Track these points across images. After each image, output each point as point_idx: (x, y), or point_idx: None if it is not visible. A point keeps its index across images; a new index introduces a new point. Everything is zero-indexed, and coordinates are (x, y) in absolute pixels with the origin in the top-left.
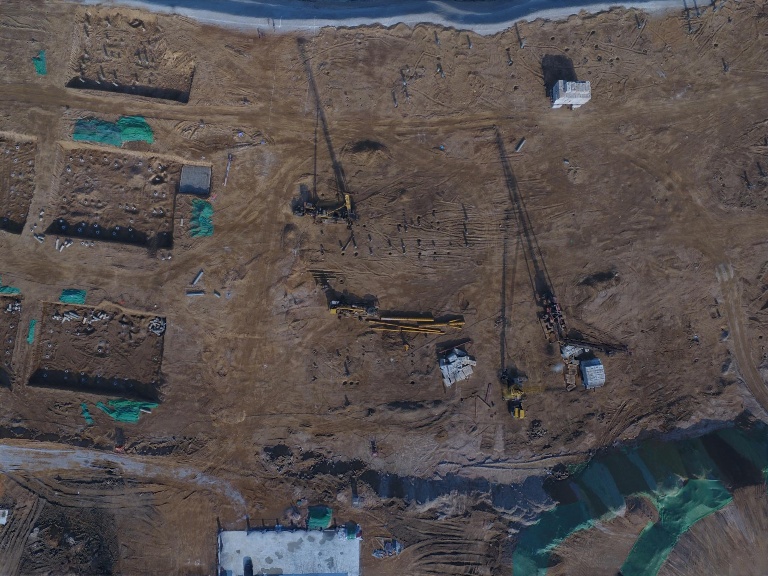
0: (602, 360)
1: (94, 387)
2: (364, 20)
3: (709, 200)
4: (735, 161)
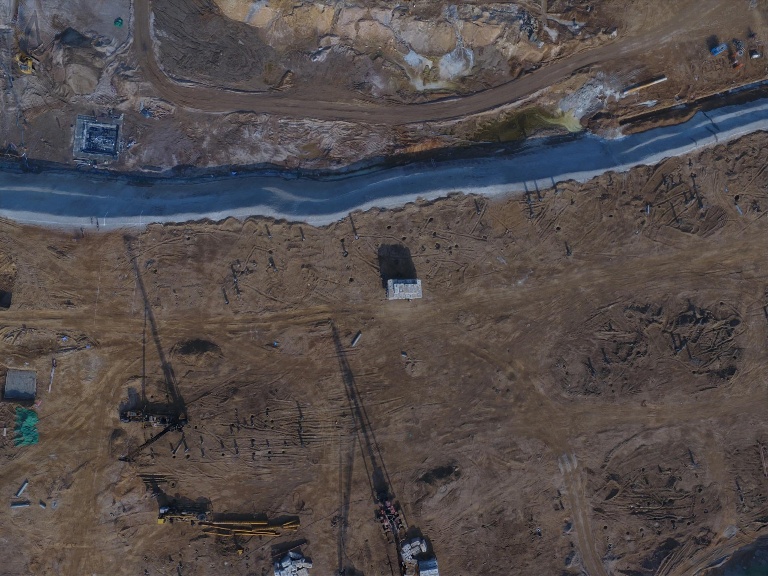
0: (442, 557)
1: None
2: (192, 216)
3: (552, 388)
4: (579, 348)
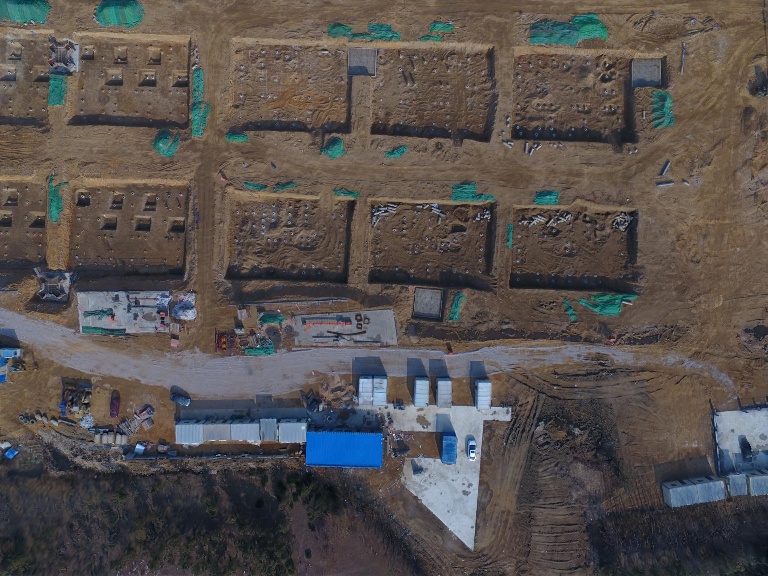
0: None
1: (566, 286)
2: None
3: None
4: None
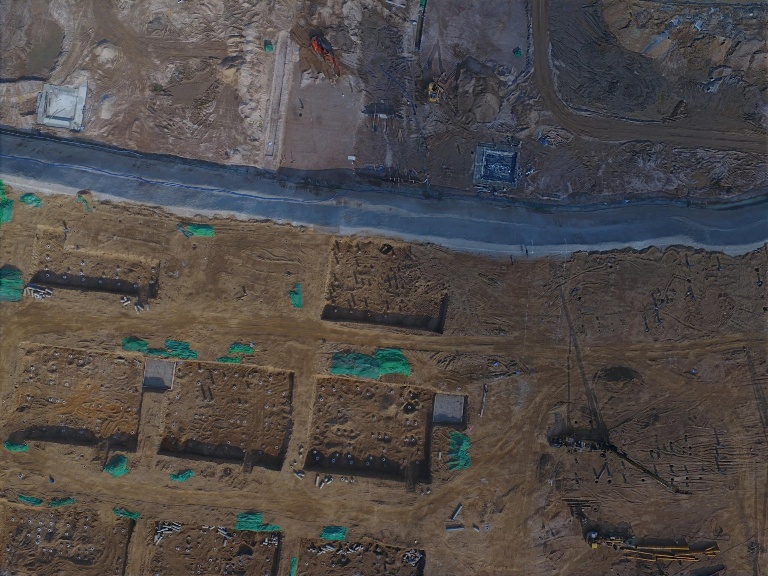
0: None
1: None
2: (616, 244)
3: None
4: None
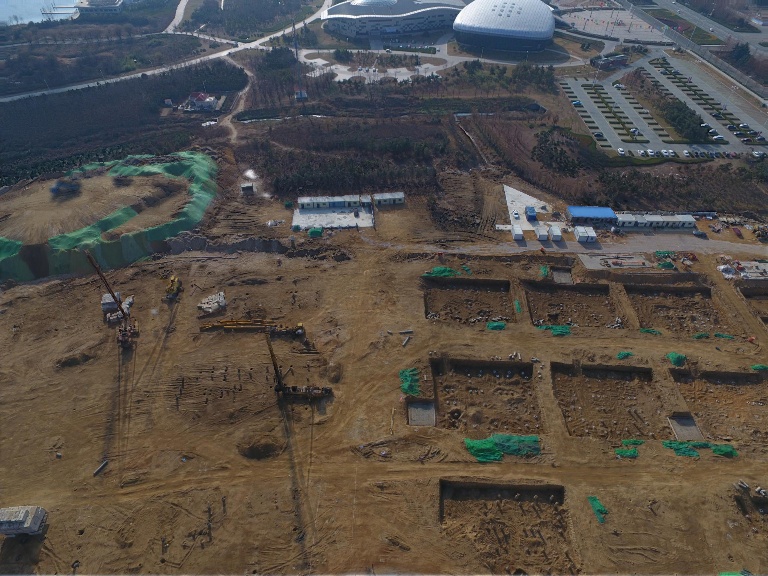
0: (99, 312)
1: (468, 285)
2: None
3: None
4: None
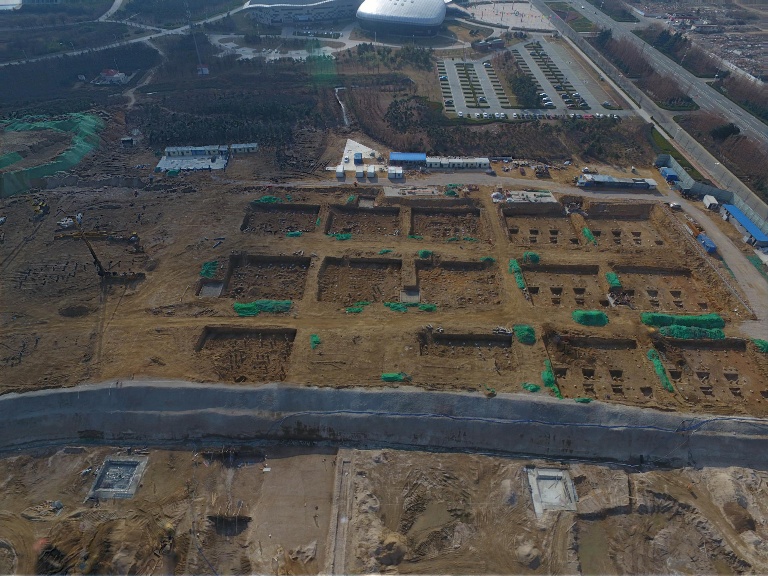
0: None
1: None
2: (33, 395)
3: None
4: None
